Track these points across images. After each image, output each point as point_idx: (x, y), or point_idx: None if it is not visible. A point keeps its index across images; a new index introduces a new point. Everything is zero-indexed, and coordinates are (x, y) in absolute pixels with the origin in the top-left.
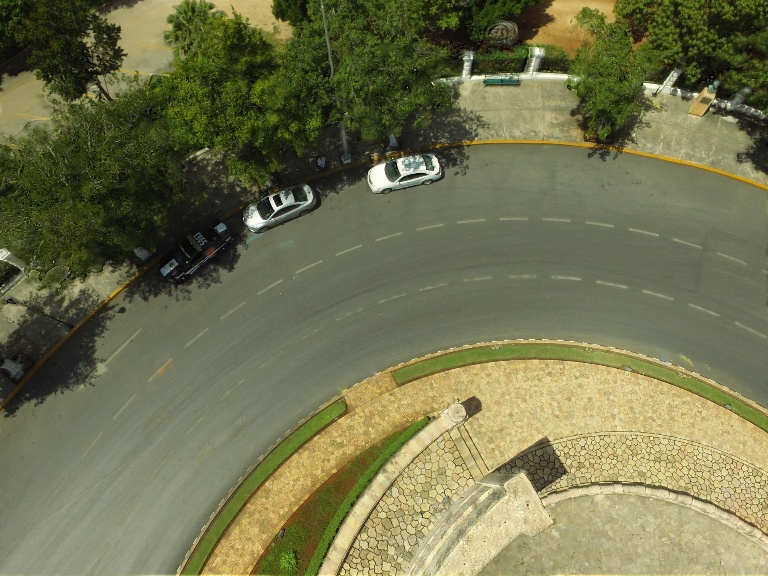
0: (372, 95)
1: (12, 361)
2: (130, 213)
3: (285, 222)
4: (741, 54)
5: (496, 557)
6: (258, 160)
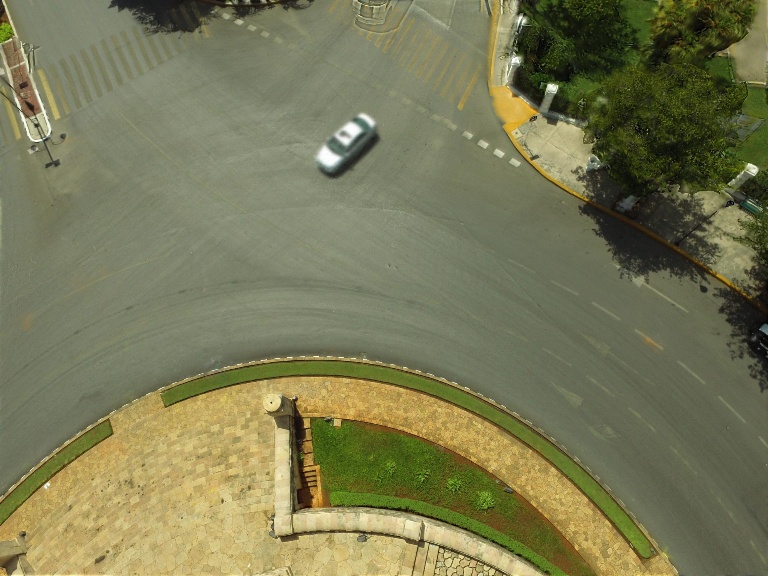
0: None
1: None
2: None
3: None
4: None
5: None
6: None
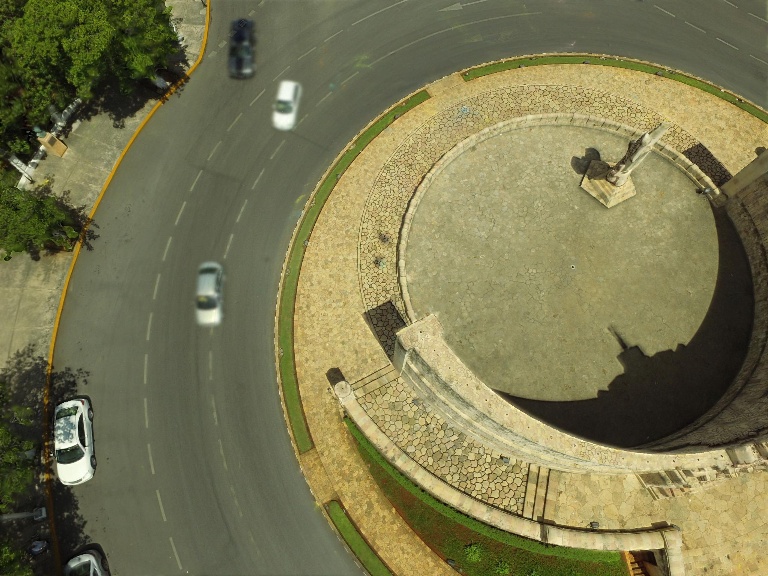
0: None
1: None
2: None
3: None
4: (12, 105)
5: None
6: None
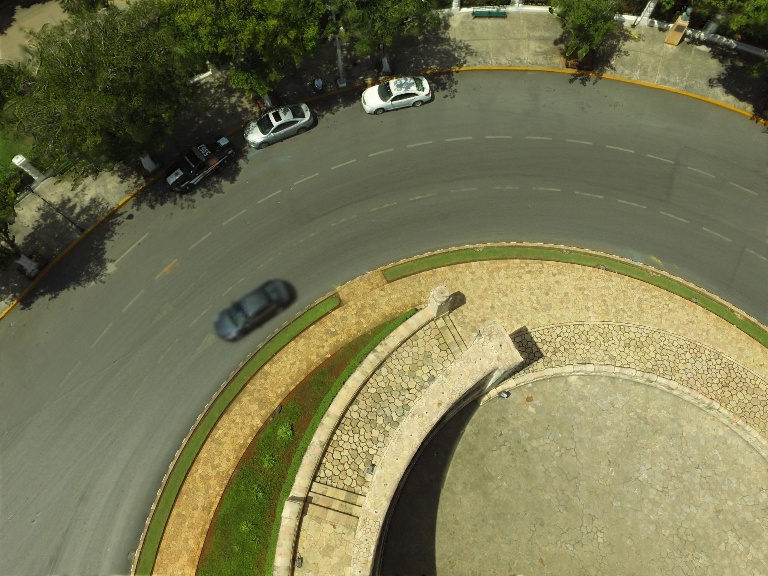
0: (365, 6)
1: (28, 258)
2: (140, 108)
3: (284, 139)
4: None
5: (477, 430)
6: (259, 70)
